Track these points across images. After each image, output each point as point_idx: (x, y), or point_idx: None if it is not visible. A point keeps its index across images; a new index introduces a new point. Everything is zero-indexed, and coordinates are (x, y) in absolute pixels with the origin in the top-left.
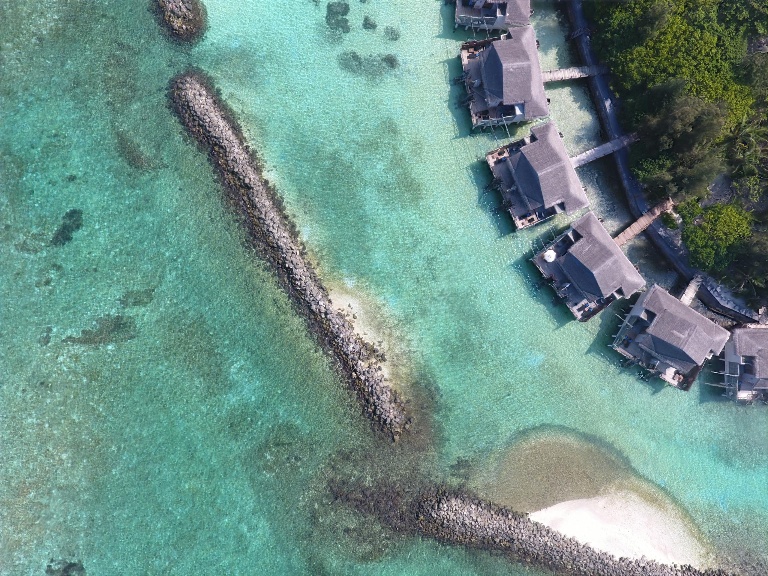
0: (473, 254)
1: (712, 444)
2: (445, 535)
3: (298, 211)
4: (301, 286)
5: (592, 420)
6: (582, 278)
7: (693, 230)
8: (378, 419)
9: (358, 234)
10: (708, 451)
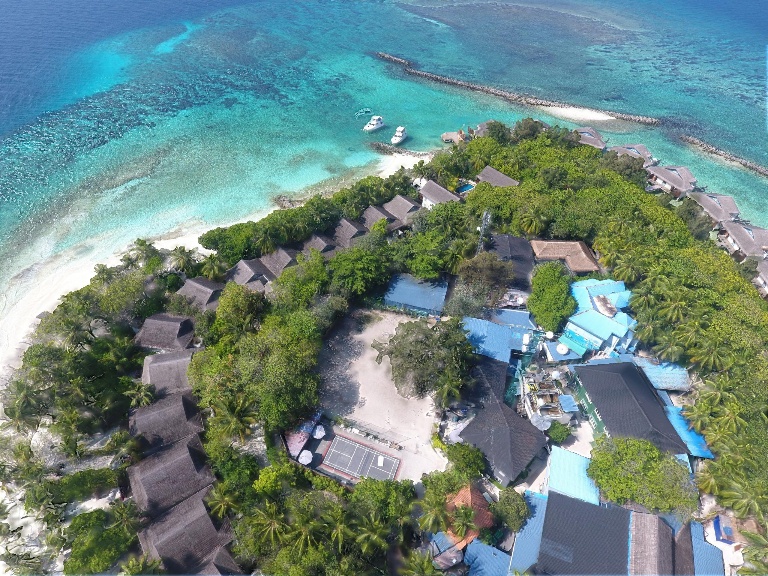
0: None
1: None
2: None
3: None
4: None
5: None
6: None
7: None
8: None
9: None
10: None
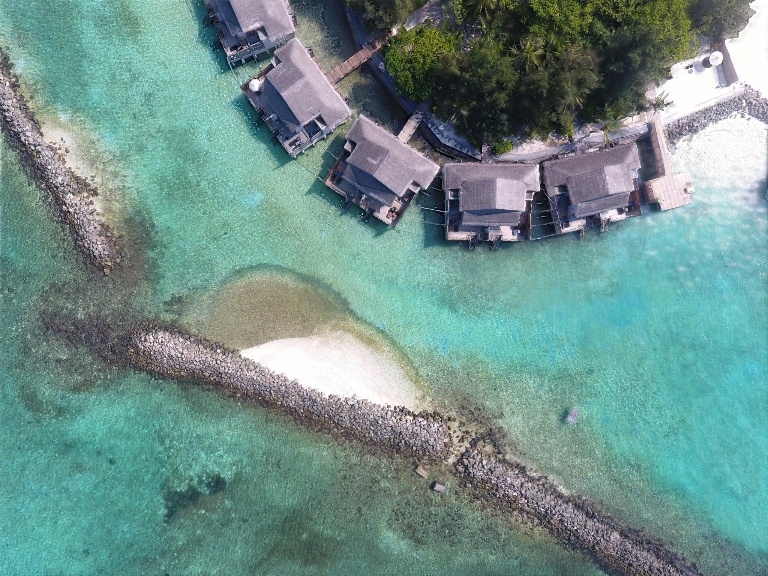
0: (192, 90)
1: (436, 289)
2: (155, 368)
3: (12, 43)
4: (9, 117)
5: (310, 261)
6: (281, 105)
7: (393, 54)
8: (89, 252)
9: (74, 68)
10: (431, 296)
